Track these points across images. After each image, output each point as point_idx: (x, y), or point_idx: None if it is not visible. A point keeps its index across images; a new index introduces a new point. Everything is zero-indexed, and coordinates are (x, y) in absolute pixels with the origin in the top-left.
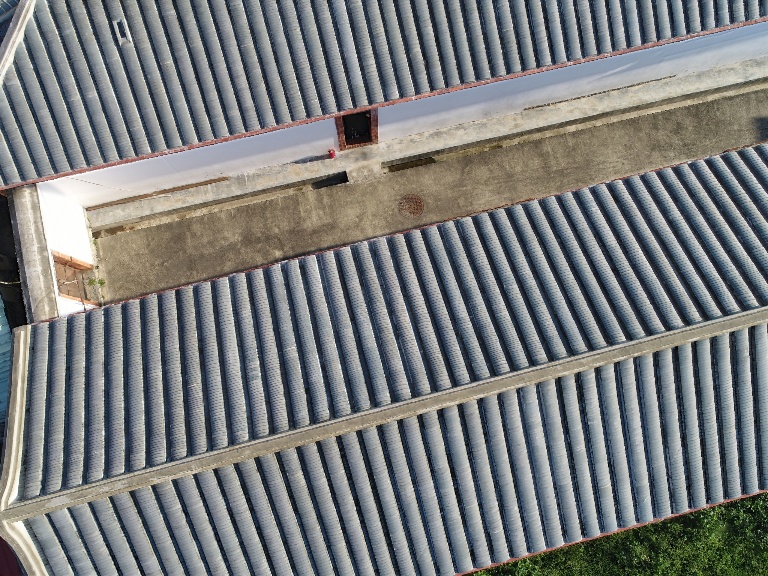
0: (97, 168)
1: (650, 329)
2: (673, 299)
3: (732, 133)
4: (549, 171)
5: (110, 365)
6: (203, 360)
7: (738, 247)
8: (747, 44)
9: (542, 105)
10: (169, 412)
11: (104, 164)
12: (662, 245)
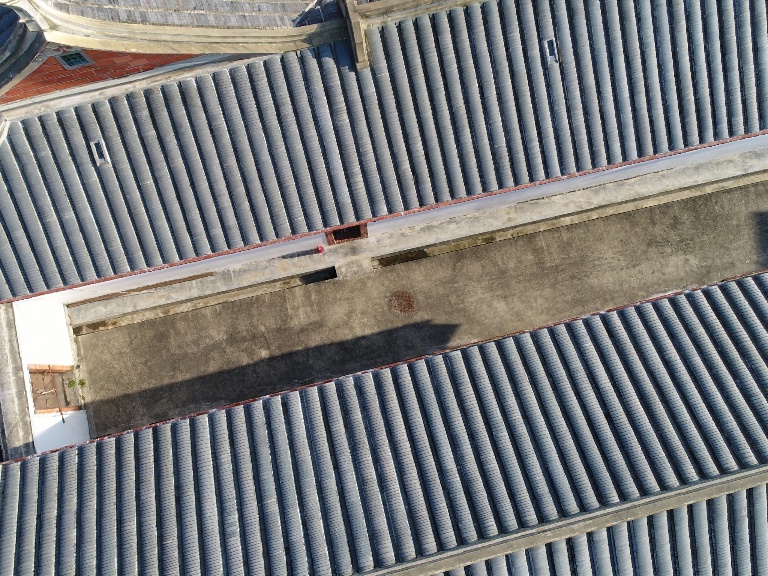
0: (74, 287)
1: (644, 488)
2: (668, 453)
3: (730, 228)
4: (543, 267)
5: (83, 515)
6: (179, 511)
7: (736, 394)
8: (746, 142)
9: (536, 199)
10: (143, 573)
11: (82, 283)
12: (657, 388)
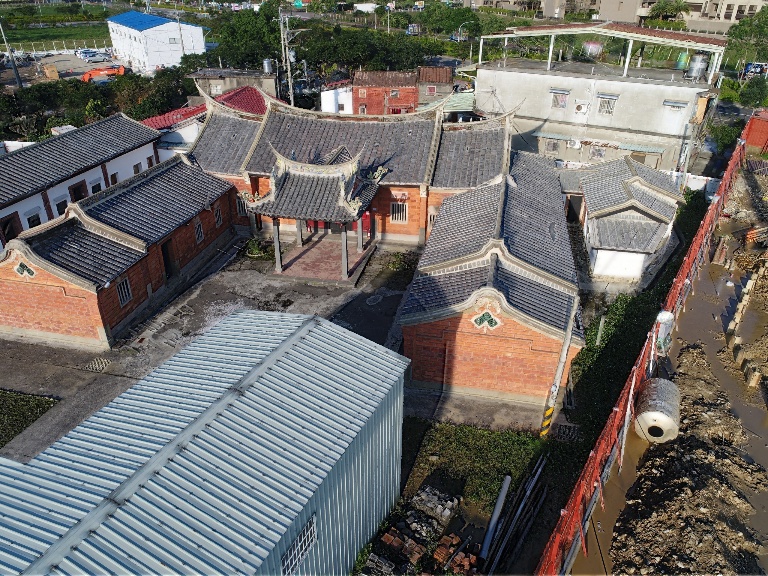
0: None
1: None
2: None
3: None
4: None
5: None
6: None
7: (4, 173)
8: None
9: None
10: None
11: None
12: None
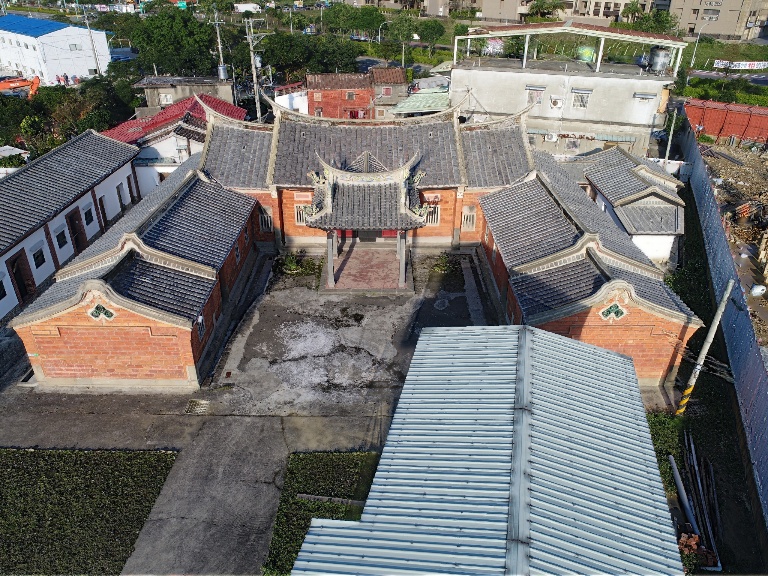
0: None
1: None
2: None
3: None
4: None
5: None
6: None
7: None
8: None
9: None
10: None
11: None
12: None
